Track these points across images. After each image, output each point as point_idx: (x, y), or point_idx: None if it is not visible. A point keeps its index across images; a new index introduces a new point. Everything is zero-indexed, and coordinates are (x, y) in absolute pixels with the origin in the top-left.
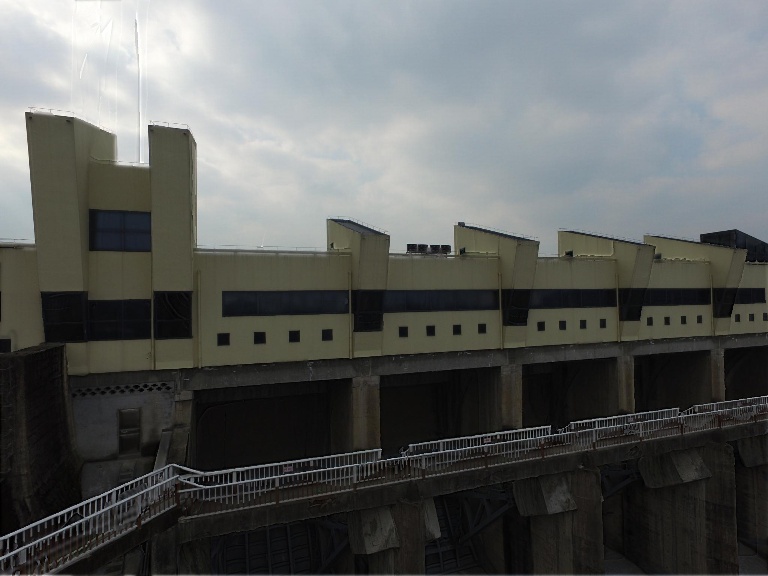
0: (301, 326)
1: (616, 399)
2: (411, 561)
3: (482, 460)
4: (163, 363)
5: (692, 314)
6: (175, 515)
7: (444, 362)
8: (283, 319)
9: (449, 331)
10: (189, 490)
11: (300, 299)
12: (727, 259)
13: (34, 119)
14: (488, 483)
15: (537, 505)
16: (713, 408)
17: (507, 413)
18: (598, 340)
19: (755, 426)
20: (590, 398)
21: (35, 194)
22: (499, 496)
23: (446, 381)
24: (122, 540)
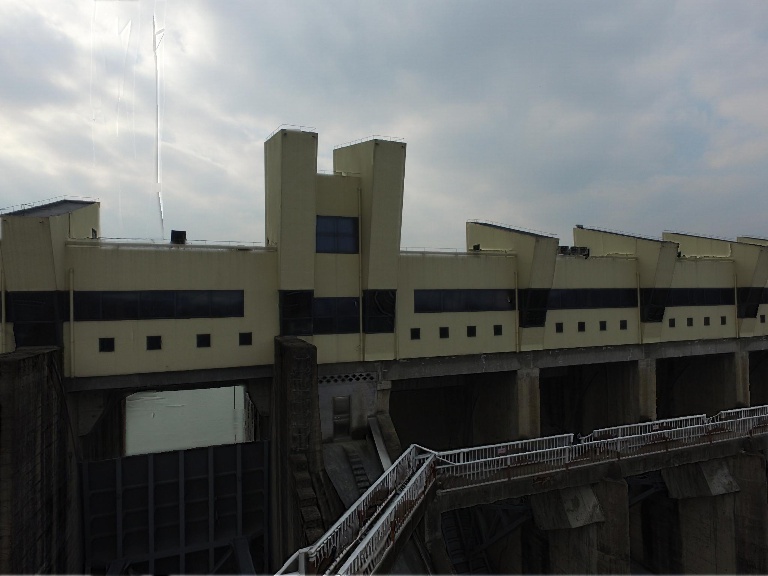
0: (477, 322)
1: (733, 392)
2: (619, 533)
3: (663, 444)
4: (370, 355)
5: None
6: (435, 488)
7: (591, 356)
8: (462, 315)
9: (596, 327)
10: (444, 466)
11: (475, 297)
12: None
13: (288, 135)
14: (669, 465)
15: (697, 487)
16: None
17: (644, 404)
18: (719, 336)
19: None
20: (702, 391)
21: (283, 202)
22: (641, 481)
23: (565, 375)
24: (420, 507)
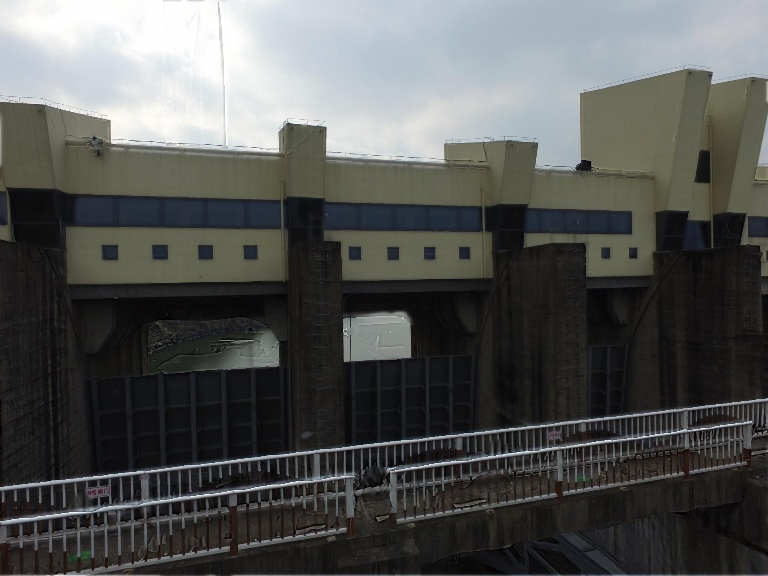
0: None
1: None
2: None
3: None
4: None
5: None
6: None
7: None
8: None
9: None
10: None
11: None
12: None
13: (691, 74)
14: None
15: None
16: None
17: None
18: None
19: None
20: None
21: (679, 133)
22: None
23: None
24: None
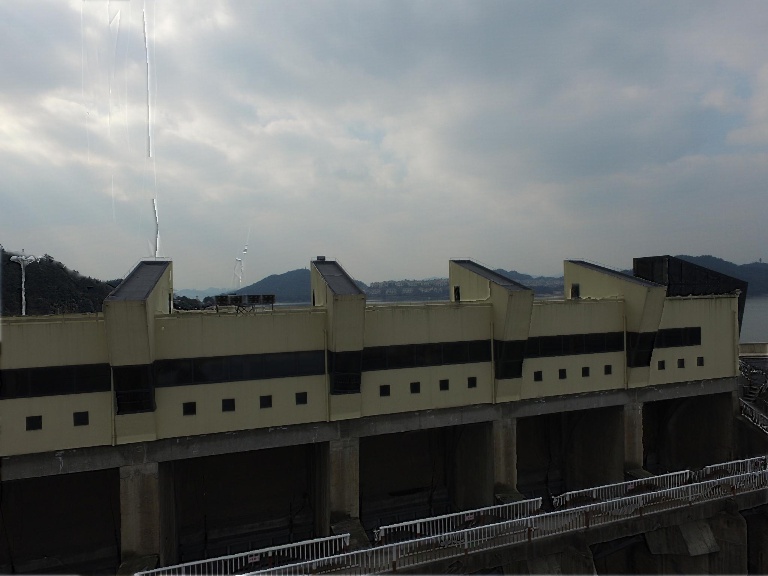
0: (44, 410)
1: (492, 470)
2: None
3: None
4: None
5: (598, 364)
6: None
7: (249, 441)
8: (18, 403)
9: (254, 404)
10: None
11: (42, 377)
12: (640, 299)
13: None
14: None
15: None
16: (592, 494)
17: (338, 496)
18: (465, 403)
19: (640, 521)
20: (472, 462)
21: None
22: None
23: None
24: None
